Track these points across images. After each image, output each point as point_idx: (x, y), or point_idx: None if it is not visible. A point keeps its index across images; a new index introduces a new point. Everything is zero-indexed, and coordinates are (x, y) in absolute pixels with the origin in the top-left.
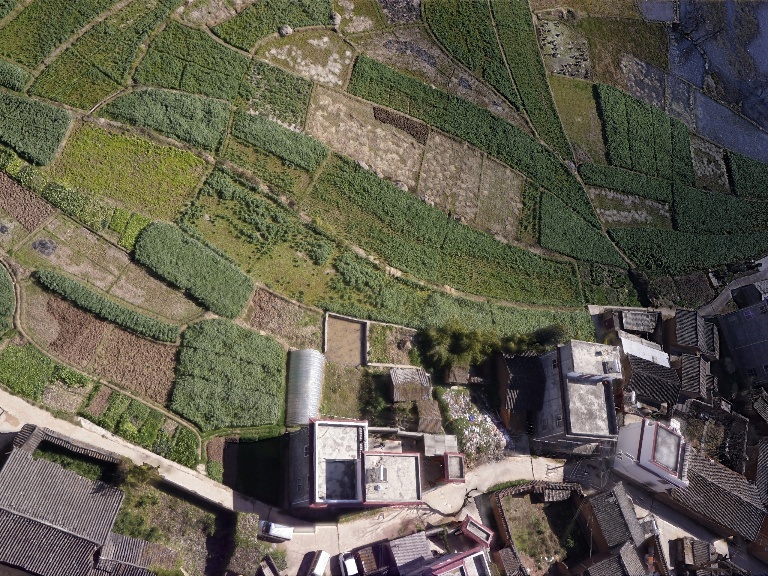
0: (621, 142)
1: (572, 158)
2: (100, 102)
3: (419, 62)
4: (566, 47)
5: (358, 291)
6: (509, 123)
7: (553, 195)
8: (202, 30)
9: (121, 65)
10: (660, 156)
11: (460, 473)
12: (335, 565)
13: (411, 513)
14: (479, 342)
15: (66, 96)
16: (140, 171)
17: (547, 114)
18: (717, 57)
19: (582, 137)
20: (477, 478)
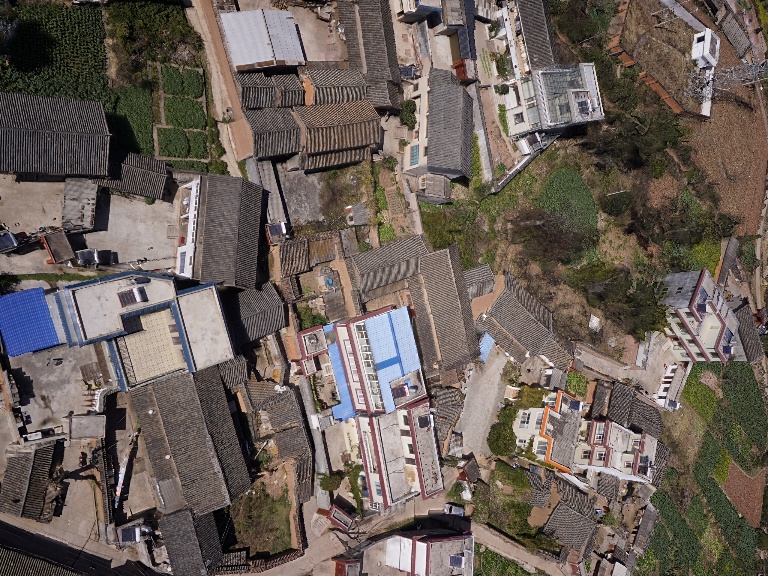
0: None
1: None
2: None
3: None
4: None
5: None
6: None
7: None
8: None
9: None
10: None
11: (348, 570)
12: None
13: (364, 529)
14: None
15: None
16: None
17: None
18: None
19: None
20: (302, 567)
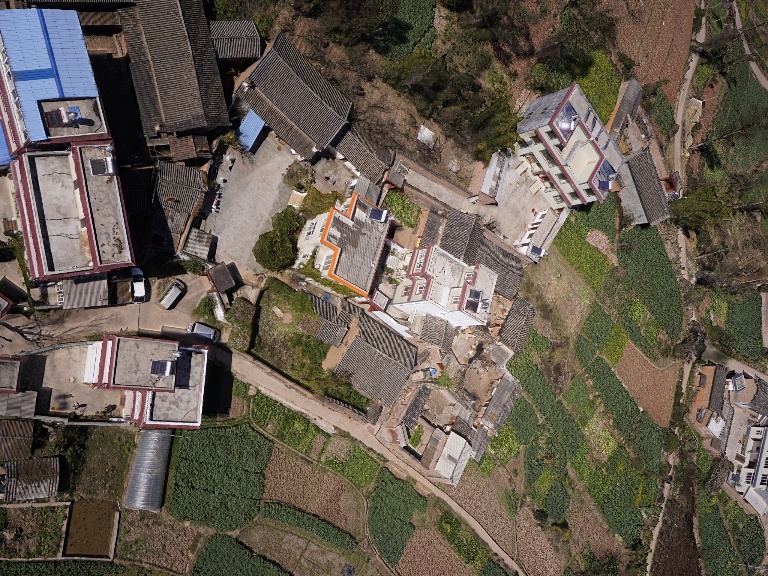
0: None
1: None
2: None
3: None
4: None
5: None
6: None
7: None
8: None
9: None
10: None
11: None
12: (146, 294)
13: (49, 331)
14: None
15: None
16: None
17: None
18: None
19: None
20: None
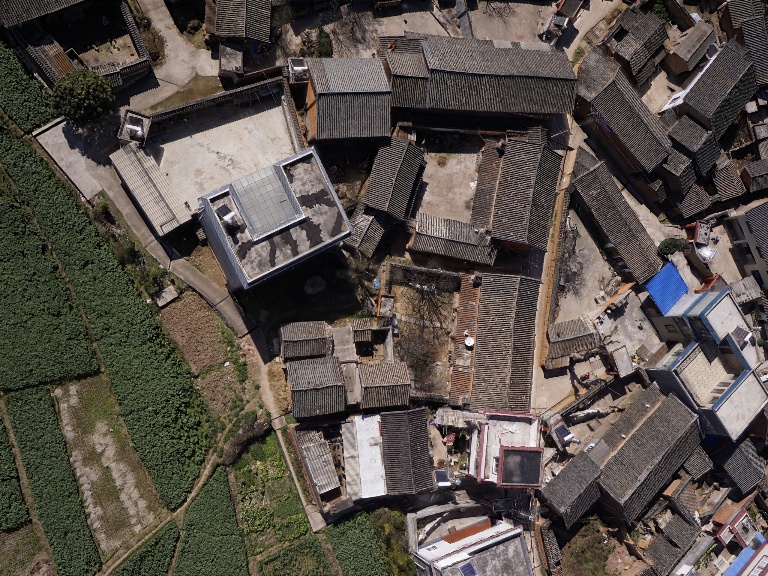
0: None
1: None
2: None
3: None
4: None
5: None
6: None
7: None
8: None
9: None
10: None
11: None
12: None
13: None
14: None
15: None
16: None
17: None
18: None
19: None
20: None
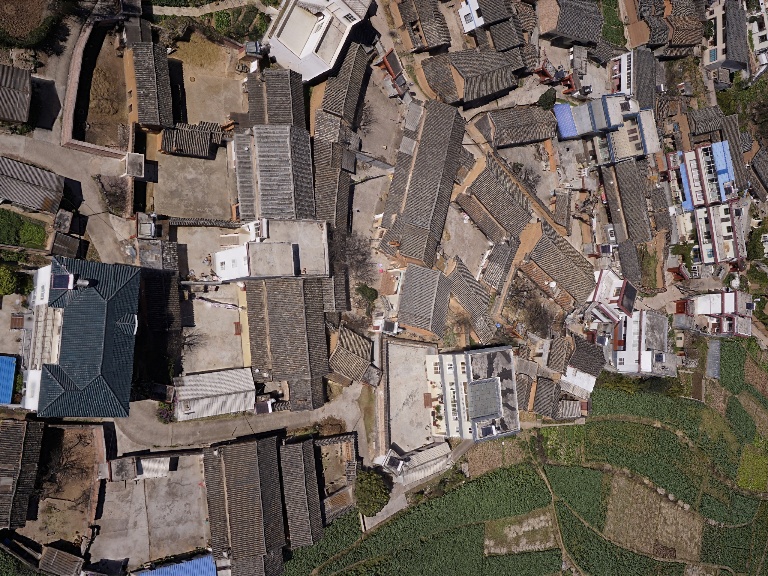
0: None
1: (563, 575)
2: (759, 507)
3: None
4: None
5: None
6: None
7: None
8: (735, 573)
9: None
10: None
11: None
12: None
13: None
14: (674, 383)
15: (766, 506)
16: None
17: None
18: None
19: None
20: (661, 302)
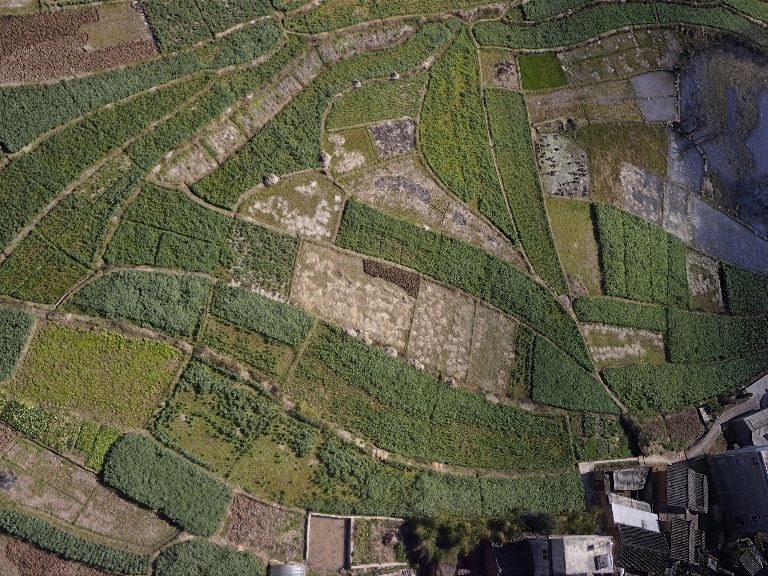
0: (617, 268)
1: (567, 292)
2: (67, 292)
3: (412, 199)
4: (565, 162)
5: (343, 482)
6: (504, 261)
7: (547, 339)
8: (180, 190)
9: (90, 245)
10: (656, 279)
11: None
12: None
13: None
14: (468, 535)
15: (29, 290)
16: (110, 372)
17: (543, 244)
18: (716, 156)
19: (578, 265)
20: None
